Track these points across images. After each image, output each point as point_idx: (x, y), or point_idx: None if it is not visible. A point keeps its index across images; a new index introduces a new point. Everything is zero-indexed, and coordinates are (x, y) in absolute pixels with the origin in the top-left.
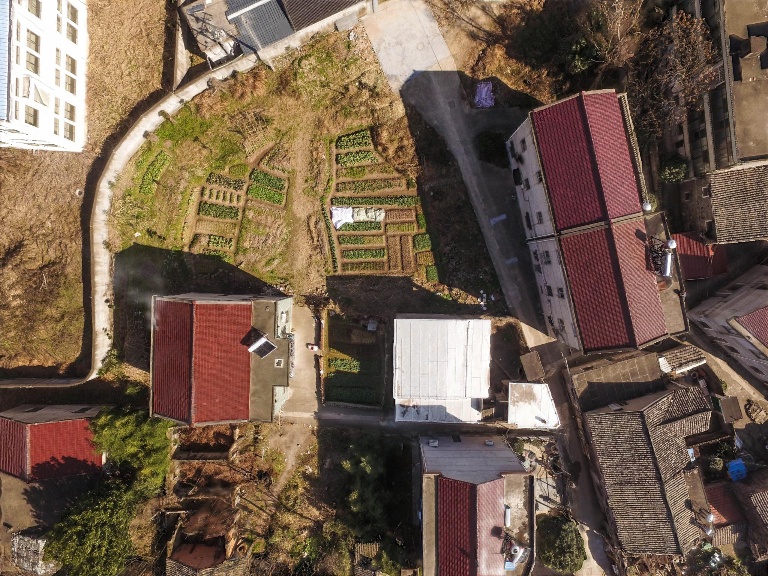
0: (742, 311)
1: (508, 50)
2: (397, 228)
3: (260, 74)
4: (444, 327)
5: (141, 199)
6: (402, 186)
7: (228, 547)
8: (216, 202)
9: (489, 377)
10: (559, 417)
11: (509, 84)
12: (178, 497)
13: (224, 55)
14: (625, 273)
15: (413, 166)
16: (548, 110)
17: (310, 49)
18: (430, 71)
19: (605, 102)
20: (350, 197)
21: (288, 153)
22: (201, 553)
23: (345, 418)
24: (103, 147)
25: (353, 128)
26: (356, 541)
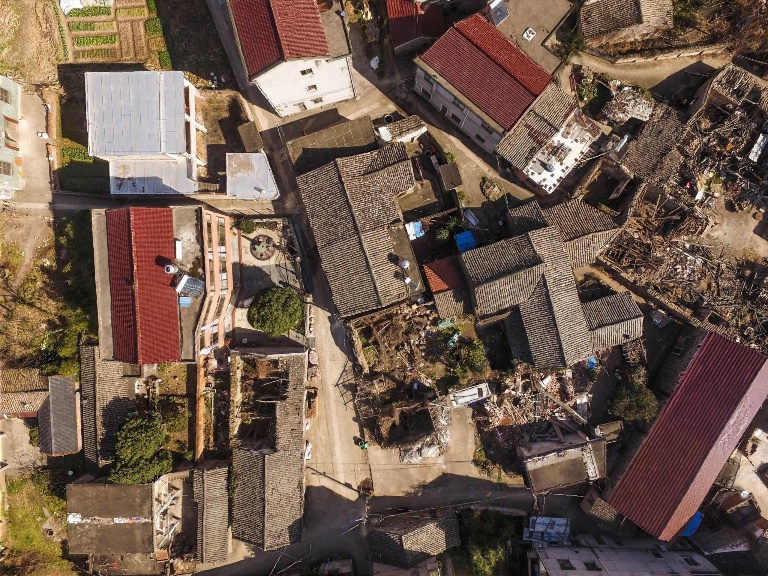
0: None
1: None
2: (127, 13)
3: None
4: (135, 79)
5: None
6: None
7: None
8: None
9: (184, 131)
10: (296, 201)
11: None
12: None
13: None
14: None
15: None
16: None
17: None
18: None
19: None
20: None
21: None
22: None
23: (80, 208)
24: None
25: None
26: None
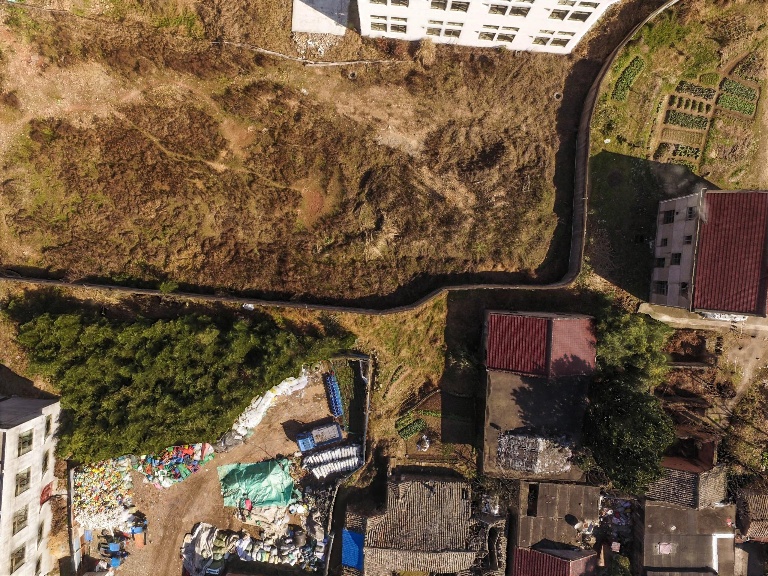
0: None
1: None
2: None
3: None
4: None
5: (613, 105)
6: None
7: None
8: (684, 111)
9: None
10: None
11: None
12: None
13: None
14: None
15: None
16: None
17: None
18: None
19: None
20: None
21: (763, 62)
22: (673, 461)
23: None
24: (590, 49)
25: None
26: None
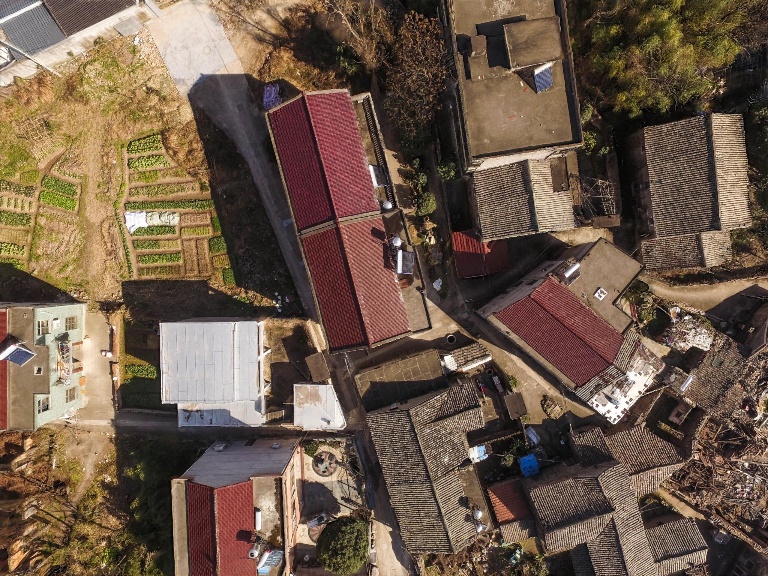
0: (502, 307)
1: (296, 53)
2: (192, 232)
3: (44, 80)
4: (210, 330)
5: None
6: (195, 190)
7: (11, 560)
8: (8, 209)
9: (258, 379)
10: (358, 418)
11: (298, 86)
12: None
13: (3, 61)
14: (359, 271)
15: (203, 169)
16: (280, 111)
17: (96, 54)
18: (218, 74)
19: (335, 102)
20: (143, 202)
21: (79, 159)
22: None
23: (143, 425)
24: None
25: (144, 132)
26: (148, 550)
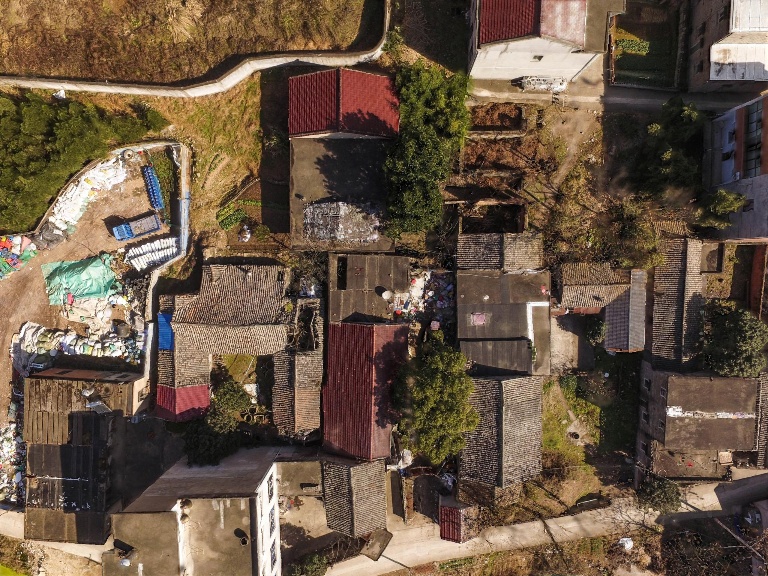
0: None
1: None
2: None
3: None
4: None
5: None
6: None
7: (527, 217)
8: None
9: None
10: None
11: None
12: (471, 170)
13: None
14: None
15: None
16: None
17: None
18: None
19: None
20: None
21: None
22: None
23: (633, 102)
24: None
25: None
26: (654, 219)
